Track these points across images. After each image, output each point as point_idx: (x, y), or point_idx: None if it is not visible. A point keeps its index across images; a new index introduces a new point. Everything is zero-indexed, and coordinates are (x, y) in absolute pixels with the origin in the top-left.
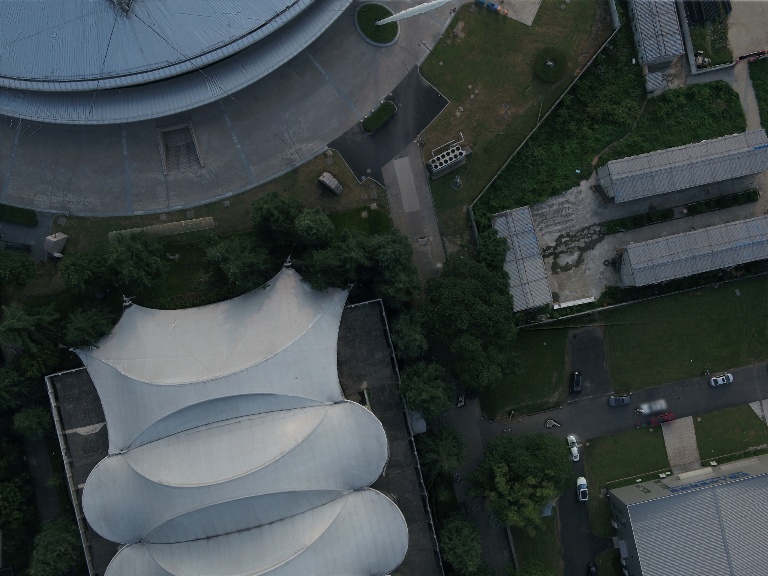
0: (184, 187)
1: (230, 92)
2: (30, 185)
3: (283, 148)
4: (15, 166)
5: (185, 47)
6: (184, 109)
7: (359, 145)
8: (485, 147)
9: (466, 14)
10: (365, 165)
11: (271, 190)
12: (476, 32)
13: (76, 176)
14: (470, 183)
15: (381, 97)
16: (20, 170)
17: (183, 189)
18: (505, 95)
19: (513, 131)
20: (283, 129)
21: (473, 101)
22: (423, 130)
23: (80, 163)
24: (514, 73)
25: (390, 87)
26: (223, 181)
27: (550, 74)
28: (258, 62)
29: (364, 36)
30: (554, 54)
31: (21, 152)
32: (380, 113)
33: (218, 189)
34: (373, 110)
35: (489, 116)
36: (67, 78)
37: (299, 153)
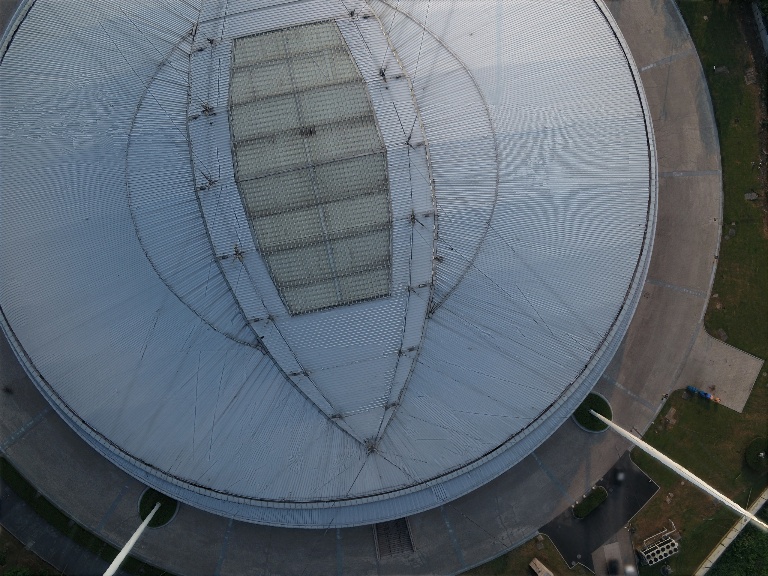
0: (395, 571)
1: (455, 498)
2: (242, 568)
3: (495, 533)
4: (228, 549)
5: (422, 472)
6: (409, 514)
7: (570, 530)
8: (694, 533)
9: (678, 401)
10: (575, 550)
11: (482, 574)
12: (688, 419)
13: (289, 559)
14: (679, 569)
15: (592, 482)
16: (233, 553)
17: (394, 573)
18: (715, 482)
19: (722, 517)
20: (495, 514)
21: (683, 488)
22: (633, 516)
23: (293, 547)
24: (725, 461)
25: (601, 472)
26: (434, 565)
27: (762, 465)
28: (483, 468)
29: (578, 424)
30: (766, 445)
31: (234, 535)
32: (592, 500)
33: (429, 573)
34: (585, 496)
35: (699, 502)
36: (303, 499)
37: (510, 538)
